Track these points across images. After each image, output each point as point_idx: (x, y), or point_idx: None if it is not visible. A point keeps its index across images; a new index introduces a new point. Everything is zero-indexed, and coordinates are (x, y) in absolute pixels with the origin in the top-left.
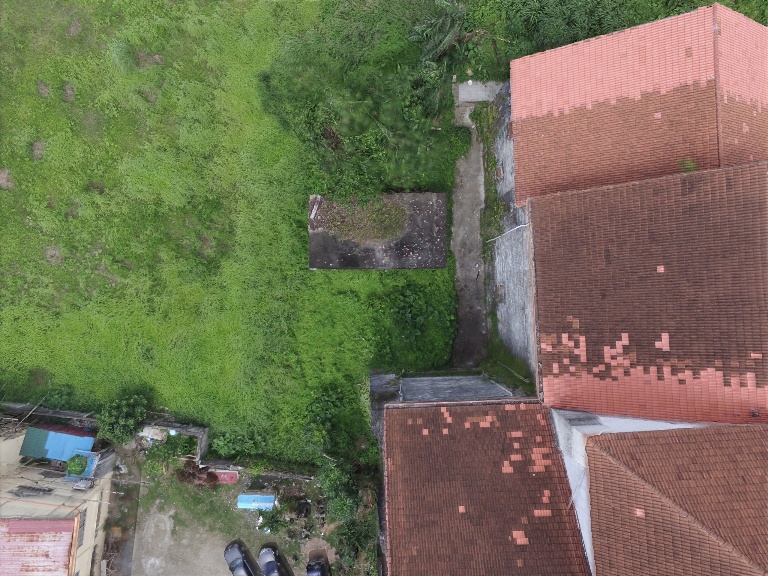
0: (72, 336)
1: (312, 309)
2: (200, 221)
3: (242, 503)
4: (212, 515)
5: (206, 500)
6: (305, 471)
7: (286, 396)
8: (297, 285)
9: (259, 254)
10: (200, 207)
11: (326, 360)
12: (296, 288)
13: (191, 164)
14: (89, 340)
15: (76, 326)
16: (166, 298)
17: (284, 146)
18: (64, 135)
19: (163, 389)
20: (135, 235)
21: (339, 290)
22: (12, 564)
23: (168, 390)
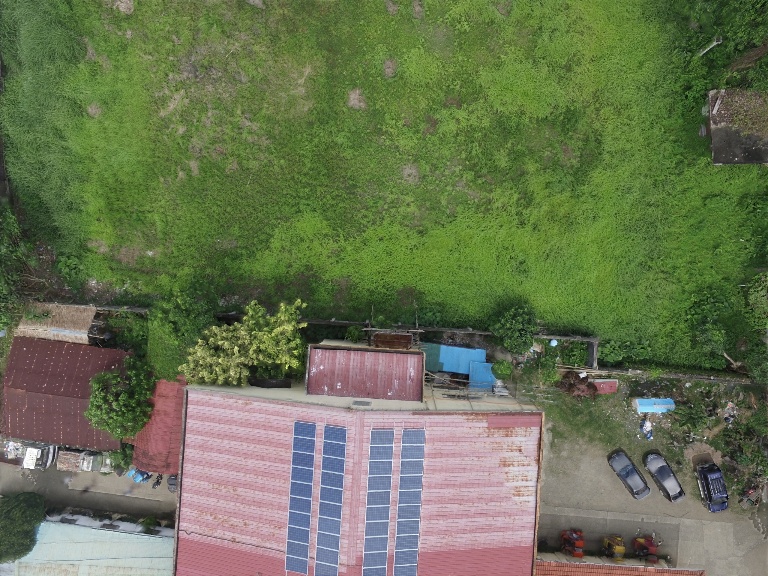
0: (440, 253)
1: (683, 214)
2: (562, 132)
3: (643, 406)
4: (592, 425)
5: (584, 411)
6: (699, 372)
7: (664, 302)
8: (668, 190)
9: (631, 160)
10: (561, 117)
11: (703, 264)
12: (666, 193)
13: (549, 75)
14: (458, 256)
15: (442, 243)
16: (535, 210)
17: (646, 51)
18: (418, 51)
19: (539, 301)
20: (496, 149)
21: (709, 193)
22: (492, 459)
23: (544, 302)
